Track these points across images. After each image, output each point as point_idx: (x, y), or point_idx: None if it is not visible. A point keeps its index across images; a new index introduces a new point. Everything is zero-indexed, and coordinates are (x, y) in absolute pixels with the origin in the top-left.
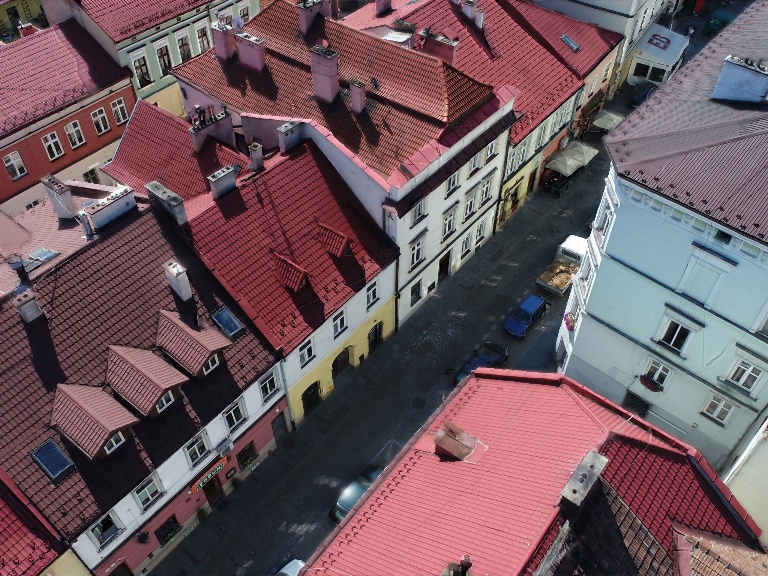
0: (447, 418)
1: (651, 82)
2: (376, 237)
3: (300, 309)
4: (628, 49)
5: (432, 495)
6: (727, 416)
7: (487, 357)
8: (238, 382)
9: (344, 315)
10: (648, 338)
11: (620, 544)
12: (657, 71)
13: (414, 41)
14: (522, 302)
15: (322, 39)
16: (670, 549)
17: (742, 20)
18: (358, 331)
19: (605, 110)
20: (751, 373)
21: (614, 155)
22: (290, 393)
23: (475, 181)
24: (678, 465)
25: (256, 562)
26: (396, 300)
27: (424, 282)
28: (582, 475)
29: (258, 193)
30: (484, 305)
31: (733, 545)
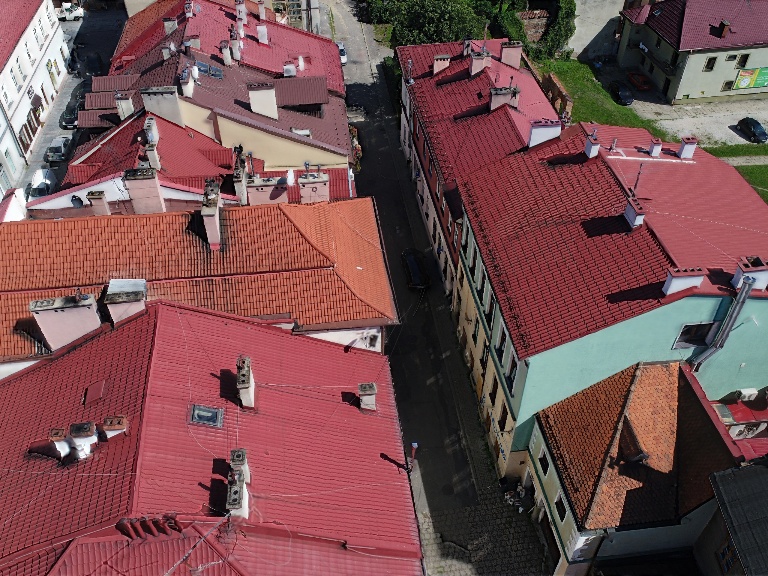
0: None
1: None
2: None
3: None
4: None
5: None
6: None
7: None
8: None
9: None
10: None
11: None
12: None
13: None
14: None
15: None
16: None
17: None
18: None
19: None
20: None
21: None
22: None
23: None
24: None
25: None
26: None
27: None
28: None
29: None
30: None
31: None
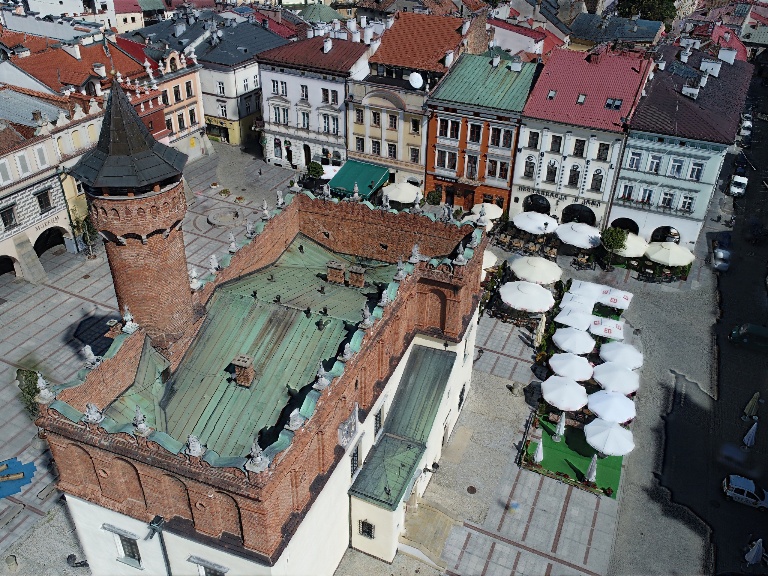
0: None
1: None
2: None
3: None
4: None
5: None
6: None
7: (742, 157)
8: None
9: None
10: None
11: None
12: None
13: None
14: None
15: None
16: None
17: None
18: None
19: None
20: None
21: None
22: None
23: None
24: None
25: (760, 137)
26: None
27: None
28: None
29: None
30: (760, 180)
31: None
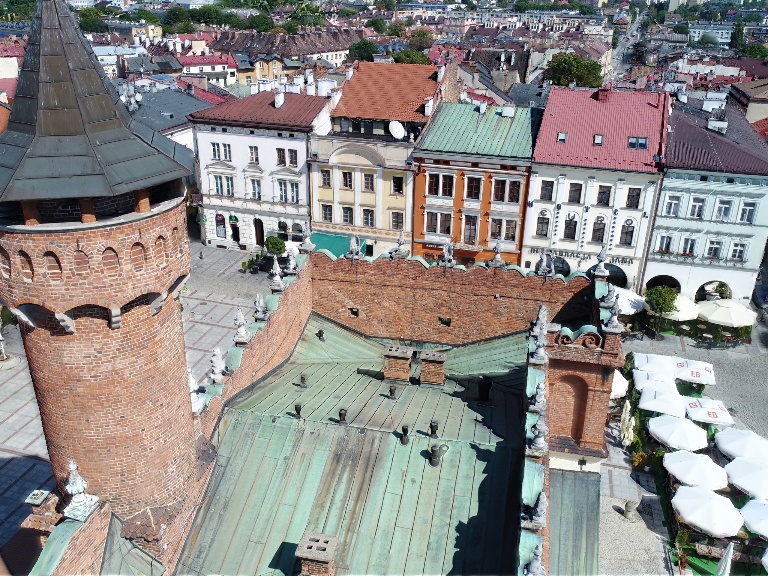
0: None
1: None
2: None
3: None
4: None
5: None
6: None
7: None
8: None
9: None
10: None
11: None
12: None
13: None
14: None
15: None
16: None
17: None
18: None
19: None
20: None
21: None
22: None
23: None
24: None
25: None
26: None
27: None
28: None
29: None
30: None
31: None
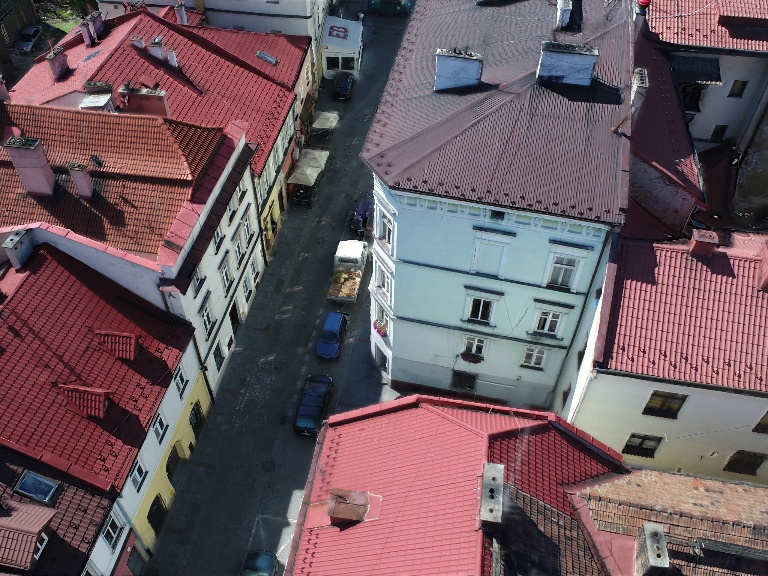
0: (324, 482)
1: (345, 72)
2: (162, 321)
3: (114, 433)
4: (315, 47)
5: (351, 571)
6: (543, 360)
7: (316, 392)
8: (79, 547)
9: (161, 415)
10: (458, 320)
11: (537, 533)
12: (347, 60)
13: (115, 100)
14: (324, 324)
15: (10, 127)
16: (571, 512)
17: (421, 7)
18: (179, 423)
19: (318, 111)
20: (552, 319)
21: (378, 170)
22: (135, 524)
23: (235, 224)
24: (546, 434)
25: None
26: (204, 373)
27: (222, 342)
28: (490, 491)
29: (10, 327)
30: (288, 340)
31: (609, 480)
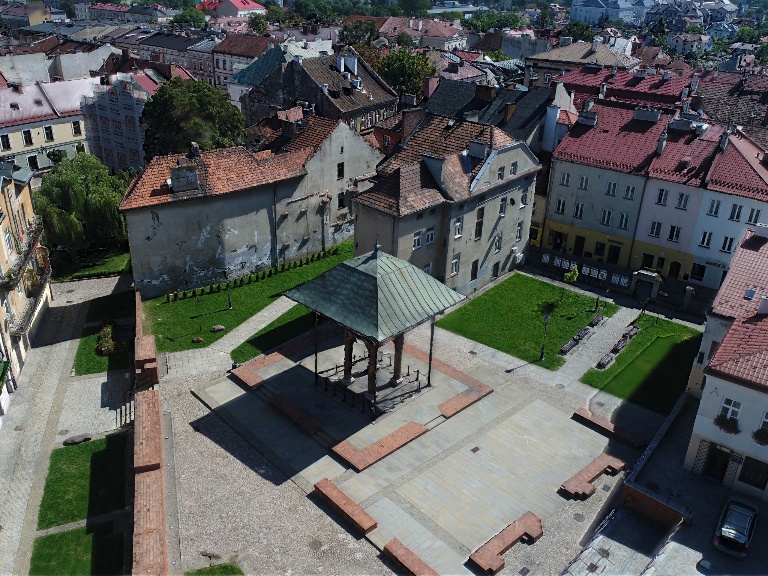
0: None
1: None
2: None
3: None
4: None
5: None
6: None
7: None
8: None
9: None
10: None
11: None
12: None
13: None
14: None
15: None
16: None
17: None
18: None
19: None
20: None
21: None
22: None
23: None
24: None
25: None
26: None
27: None
28: None
29: None
30: None
31: None
